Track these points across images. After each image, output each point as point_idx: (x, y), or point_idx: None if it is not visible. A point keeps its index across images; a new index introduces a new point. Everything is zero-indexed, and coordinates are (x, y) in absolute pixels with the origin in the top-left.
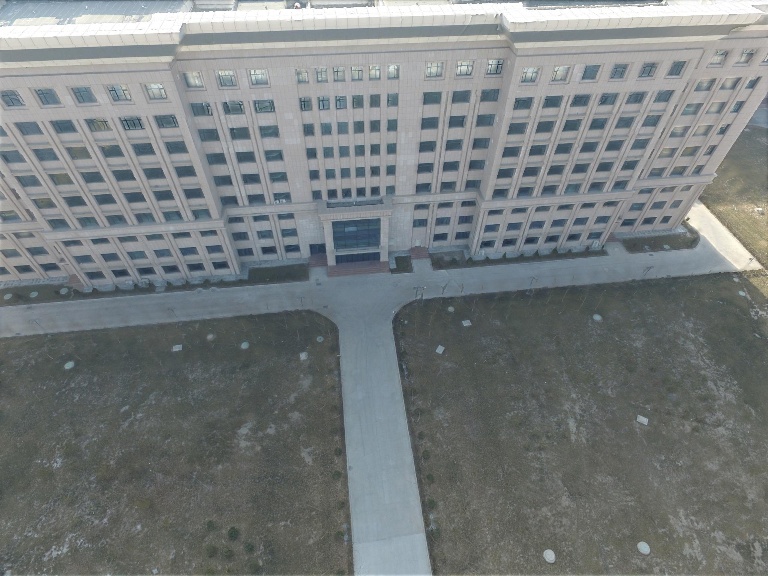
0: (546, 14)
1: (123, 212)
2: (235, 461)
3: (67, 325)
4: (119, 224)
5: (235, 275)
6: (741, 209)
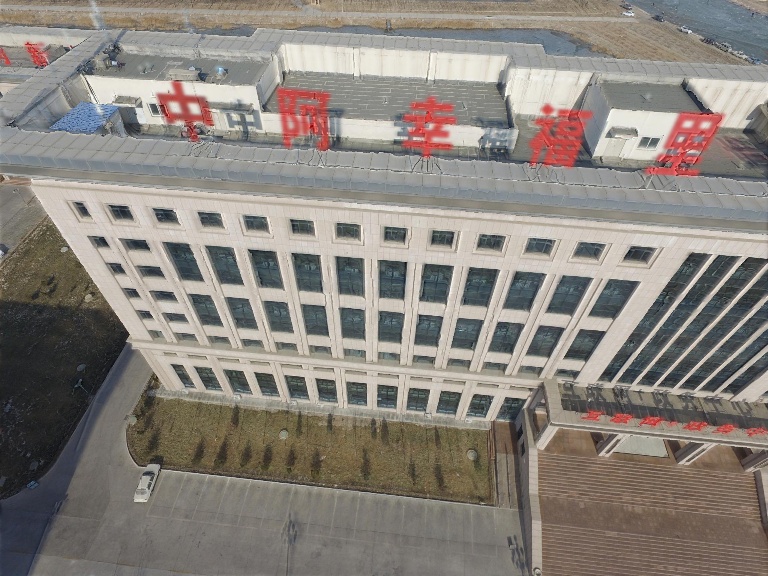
0: (497, 47)
1: None
2: None
3: None
4: None
5: None
6: (106, 304)
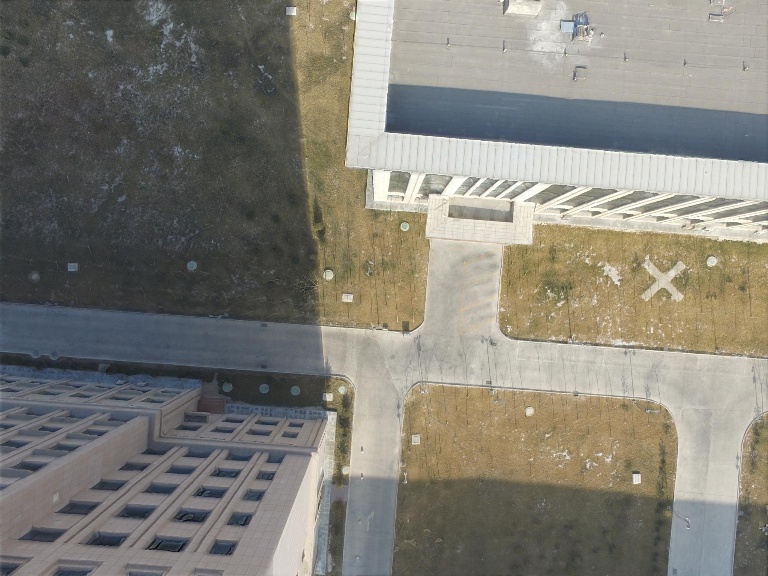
0: None
1: (8, 415)
2: (5, 118)
3: (210, 328)
4: (45, 413)
5: (6, 373)
6: None
